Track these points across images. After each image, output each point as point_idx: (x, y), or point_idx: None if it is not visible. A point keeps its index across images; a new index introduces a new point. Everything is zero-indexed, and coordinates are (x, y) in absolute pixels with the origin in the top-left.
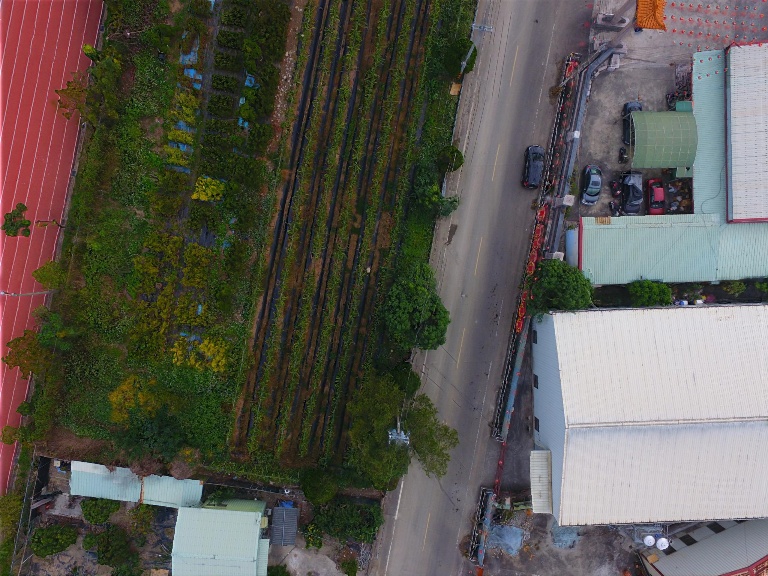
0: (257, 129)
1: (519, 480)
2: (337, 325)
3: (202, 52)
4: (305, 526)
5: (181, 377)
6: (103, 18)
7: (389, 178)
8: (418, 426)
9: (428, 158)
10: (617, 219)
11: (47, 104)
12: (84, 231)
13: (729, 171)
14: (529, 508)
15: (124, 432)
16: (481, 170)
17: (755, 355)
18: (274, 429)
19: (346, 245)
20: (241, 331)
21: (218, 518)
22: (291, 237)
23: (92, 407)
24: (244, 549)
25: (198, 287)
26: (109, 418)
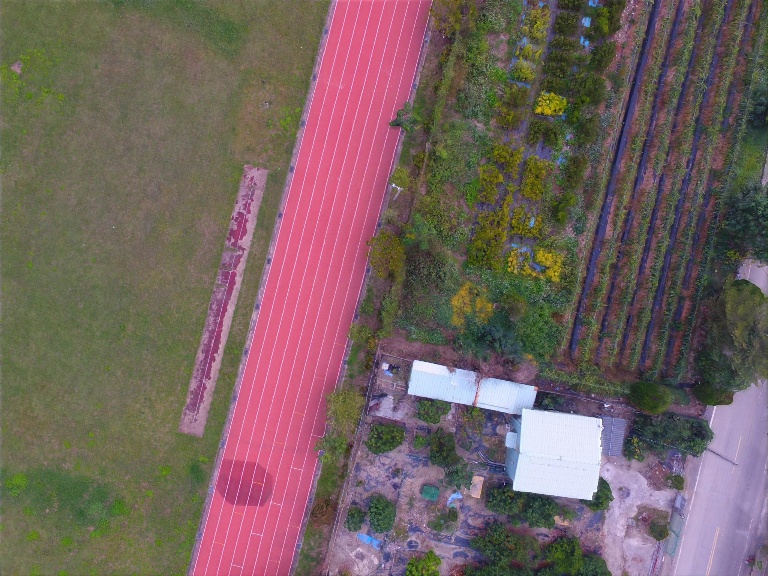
0: (608, 45)
1: None
2: None
3: None
4: (626, 439)
5: (513, 286)
6: None
7: None
8: None
9: (765, 81)
10: None
11: (394, 19)
12: (435, 139)
13: None
14: None
15: None
16: None
17: None
18: None
19: None
20: (574, 244)
21: (562, 421)
22: (635, 152)
23: (435, 309)
24: (589, 452)
25: (536, 199)
26: (451, 321)
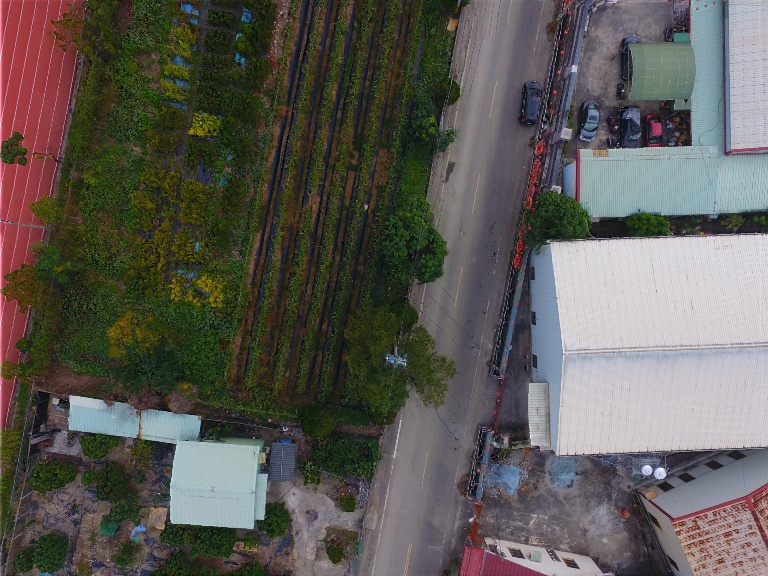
0: (254, 63)
1: (517, 419)
2: (335, 263)
3: None
4: (303, 463)
5: (179, 314)
6: None
7: (386, 115)
8: (415, 355)
9: (425, 94)
10: (615, 151)
11: (43, 41)
12: (81, 166)
13: (727, 102)
14: (527, 447)
15: (122, 368)
16: (478, 107)
17: (753, 283)
18: (272, 367)
19: (343, 182)
20: (239, 268)
21: (216, 451)
22: (288, 172)
23: (90, 342)
24: (242, 481)
25: (195, 223)
26: (107, 353)
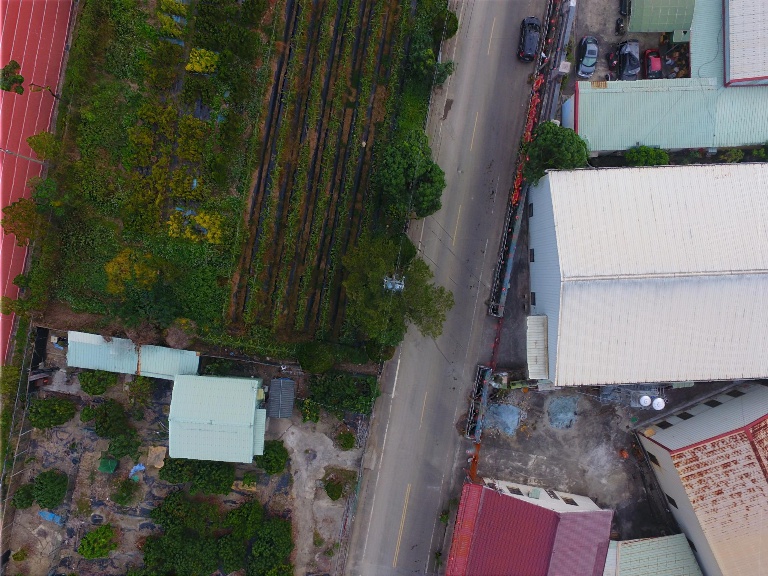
0: None
1: (516, 359)
2: (333, 200)
3: None
4: (302, 401)
5: (177, 251)
6: None
7: (384, 51)
8: (413, 284)
9: (423, 29)
10: (613, 83)
11: None
12: (78, 101)
13: (726, 32)
14: (526, 387)
15: (120, 304)
16: (477, 44)
17: (752, 210)
18: (270, 305)
19: (341, 118)
20: (236, 204)
21: (215, 385)
22: (286, 107)
23: (88, 277)
24: (241, 415)
25: (193, 160)
26: (105, 288)
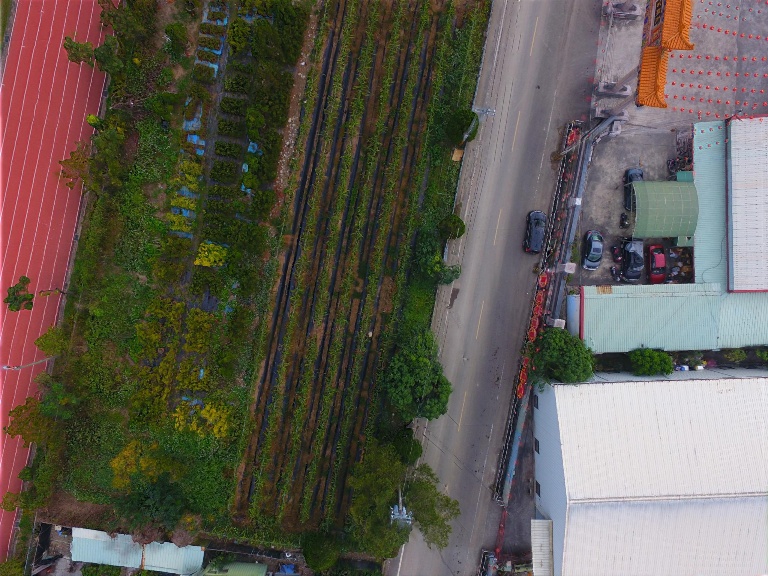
0: (260, 196)
1: (520, 542)
2: (339, 389)
3: (205, 118)
4: None
5: (183, 442)
6: (107, 83)
7: (391, 243)
8: (420, 499)
9: (430, 224)
10: (618, 288)
11: (50, 169)
12: (87, 298)
13: (730, 241)
14: (530, 570)
15: (125, 498)
16: (483, 234)
17: (756, 429)
18: (275, 493)
19: (348, 310)
20: (243, 396)
21: None
22: (293, 304)
23: (94, 473)
24: None
25: (200, 352)
26: (111, 484)
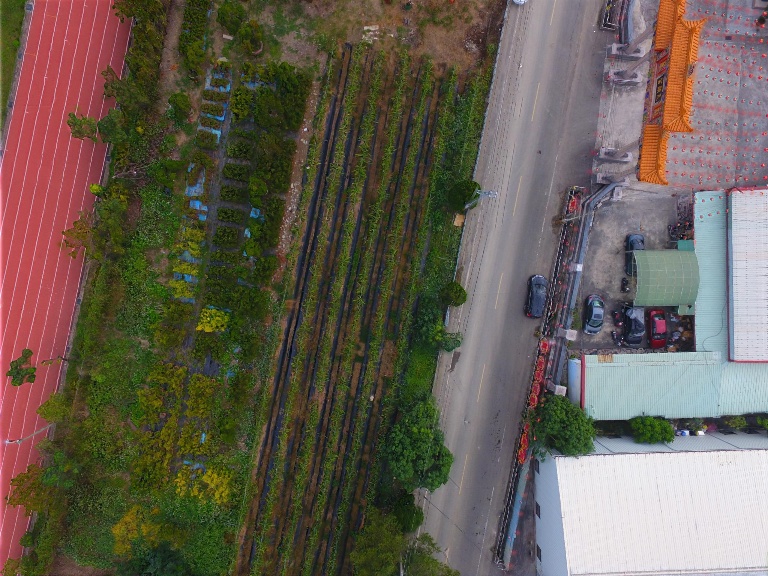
0: (262, 263)
1: None
2: (340, 452)
3: (208, 184)
4: None
5: (184, 506)
6: (110, 148)
7: (393, 307)
8: (421, 571)
9: (432, 288)
10: (619, 357)
11: (53, 233)
12: (89, 364)
13: (731, 311)
14: None
15: (127, 563)
16: (484, 298)
17: (757, 502)
18: (277, 556)
19: (350, 374)
20: (244, 460)
21: None
22: (295, 370)
23: (95, 540)
24: None
25: (202, 417)
26: (112, 551)
